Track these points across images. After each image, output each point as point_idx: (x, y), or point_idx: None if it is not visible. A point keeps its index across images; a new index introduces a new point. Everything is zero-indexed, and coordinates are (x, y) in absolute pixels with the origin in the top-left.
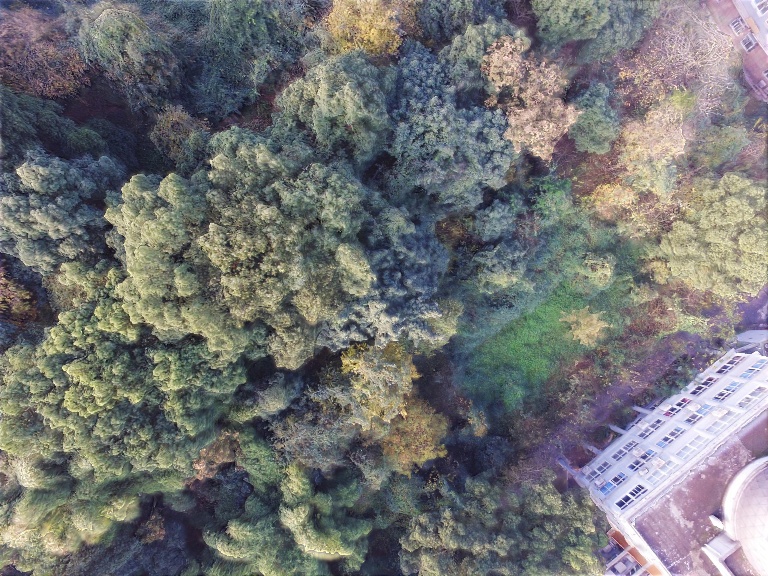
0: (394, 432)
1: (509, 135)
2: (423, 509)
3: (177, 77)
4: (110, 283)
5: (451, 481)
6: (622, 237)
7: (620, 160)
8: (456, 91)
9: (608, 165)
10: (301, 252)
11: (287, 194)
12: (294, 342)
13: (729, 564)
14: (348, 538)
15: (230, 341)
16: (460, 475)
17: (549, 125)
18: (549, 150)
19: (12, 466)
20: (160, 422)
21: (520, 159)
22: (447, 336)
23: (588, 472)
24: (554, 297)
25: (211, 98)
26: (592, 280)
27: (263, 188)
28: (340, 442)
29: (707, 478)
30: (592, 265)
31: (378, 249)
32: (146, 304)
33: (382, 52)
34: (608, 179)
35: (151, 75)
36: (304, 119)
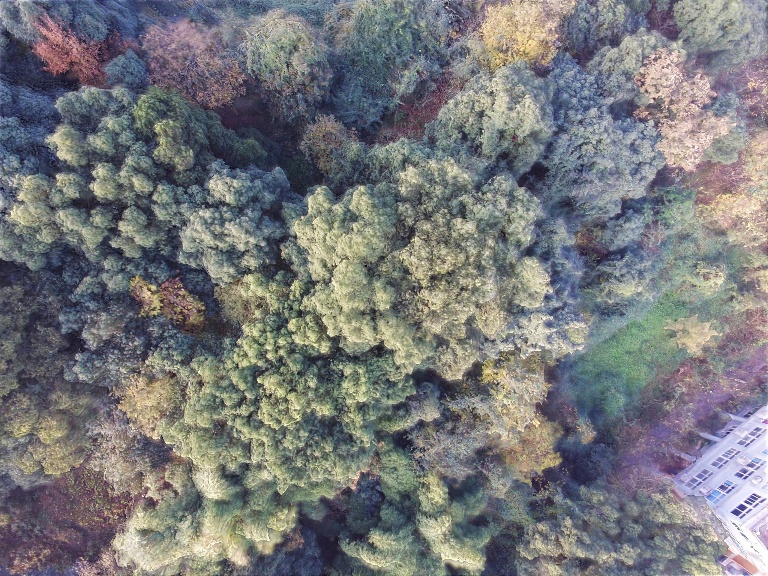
0: None
1: (665, 147)
2: (535, 517)
3: (328, 87)
4: (294, 295)
5: (560, 488)
6: None
7: (745, 170)
8: (612, 103)
9: (730, 175)
10: (494, 265)
11: (482, 208)
12: (466, 354)
13: None
14: (475, 546)
15: (419, 354)
16: (569, 483)
17: (706, 137)
18: None
19: (195, 477)
20: (337, 433)
21: None
22: None
23: (688, 479)
24: (657, 305)
25: (353, 107)
26: (700, 288)
27: (449, 201)
28: None
29: None
30: (705, 274)
31: (540, 260)
32: (348, 317)
33: (536, 63)
34: (729, 189)
35: (307, 85)
36: (470, 130)
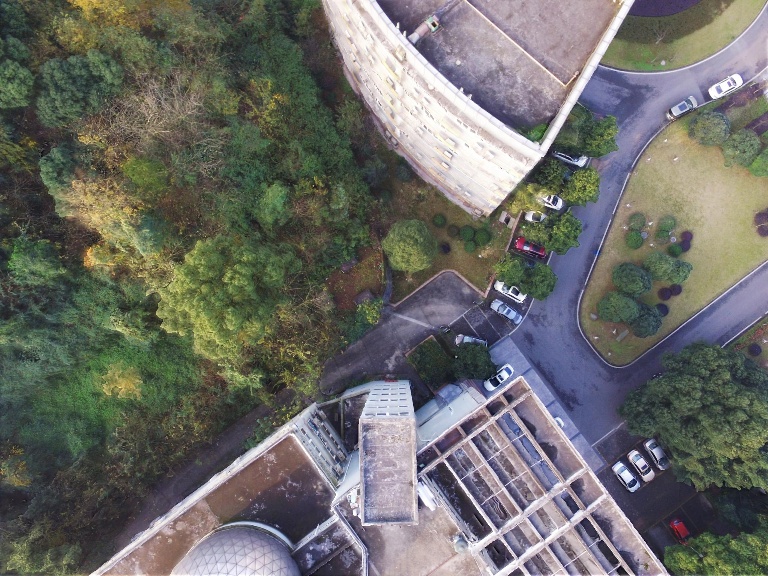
0: None
1: None
2: None
3: None
4: None
5: None
6: None
7: (91, 223)
8: None
9: None
10: None
11: None
12: None
13: None
14: None
15: None
16: None
17: None
18: None
19: None
20: None
21: None
22: None
23: (152, 523)
24: (116, 348)
25: None
26: None
27: None
28: None
29: (174, 542)
30: (112, 321)
31: None
32: None
33: None
34: (96, 240)
35: None
36: None
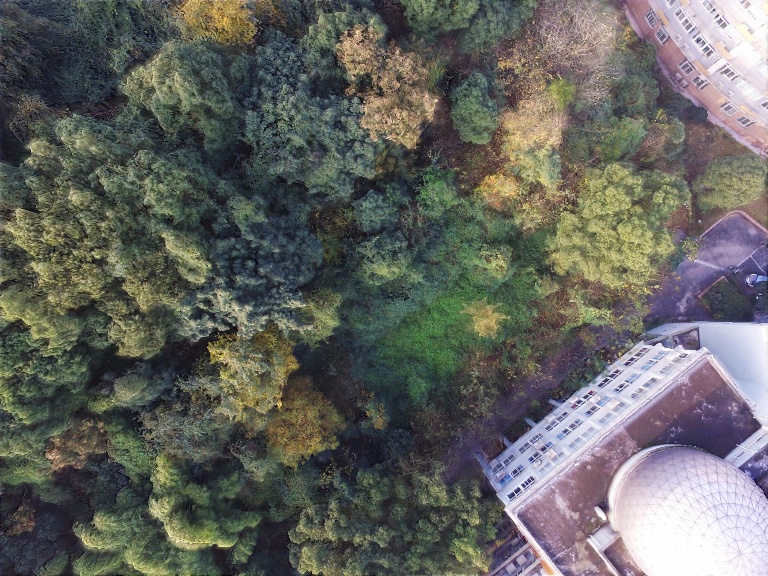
0: (280, 424)
1: (363, 123)
2: (318, 502)
3: (35, 67)
4: None
5: (348, 474)
6: (524, 229)
7: (503, 150)
8: (310, 79)
9: (494, 156)
10: (120, 238)
11: (104, 180)
12: (132, 330)
13: (609, 555)
14: (228, 530)
15: (52, 328)
16: (357, 468)
17: (401, 113)
18: (412, 139)
19: None
20: None
21: (396, 149)
22: (329, 327)
23: (494, 465)
24: (458, 289)
25: (78, 89)
26: (490, 272)
27: (88, 175)
28: (218, 433)
29: (593, 469)
30: (486, 256)
31: (226, 237)
32: None
33: (238, 41)
34: (494, 170)
35: (6, 65)
36: (148, 107)
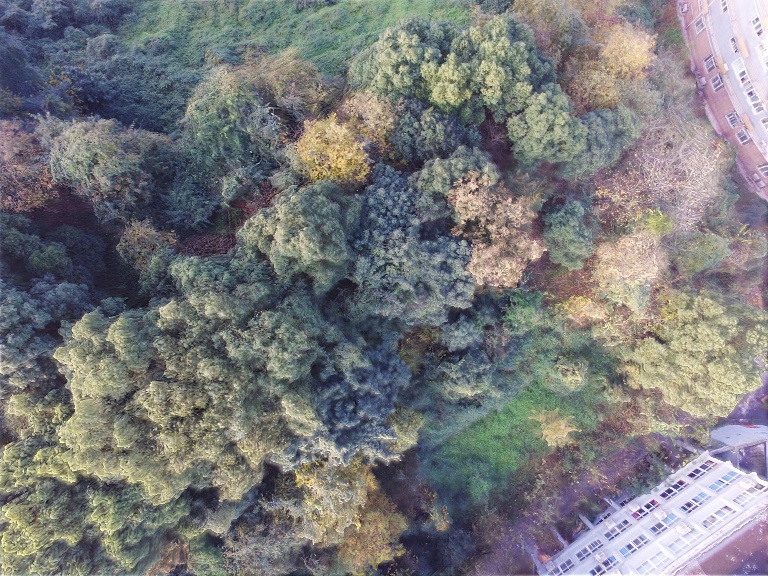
0: (351, 533)
1: (471, 270)
2: None
3: (145, 190)
4: (57, 418)
5: (409, 575)
6: (598, 338)
7: (593, 276)
8: (420, 223)
9: (582, 278)
10: (243, 406)
11: (232, 349)
12: (239, 479)
13: None
14: None
15: (170, 488)
16: (419, 571)
17: (512, 264)
18: (514, 280)
19: None
20: (101, 553)
21: None
22: (408, 444)
23: (551, 569)
24: (526, 392)
25: (181, 206)
26: (563, 382)
27: (212, 334)
28: (294, 546)
29: None
30: (563, 371)
31: (331, 382)
32: (85, 456)
33: (349, 178)
34: (581, 291)
35: (119, 190)
36: (263, 251)
